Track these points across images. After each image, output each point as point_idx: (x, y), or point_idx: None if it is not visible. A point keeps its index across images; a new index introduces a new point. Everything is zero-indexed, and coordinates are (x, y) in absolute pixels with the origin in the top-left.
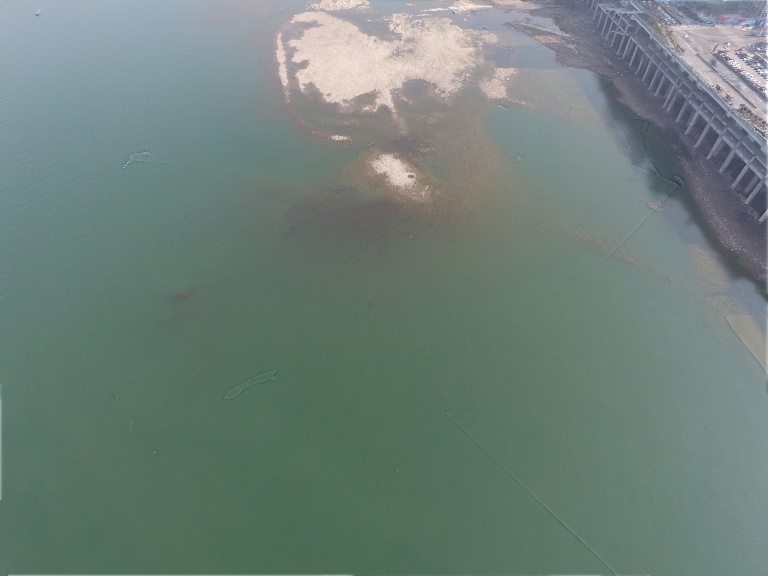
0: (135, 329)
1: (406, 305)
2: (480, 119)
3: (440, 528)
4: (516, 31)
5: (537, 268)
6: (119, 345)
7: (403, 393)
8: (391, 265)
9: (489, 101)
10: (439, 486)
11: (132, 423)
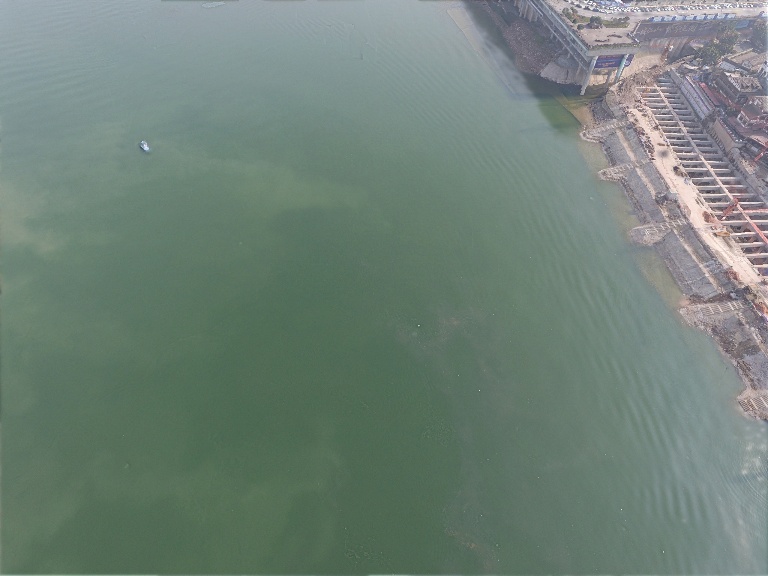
0: (151, 17)
1: (294, 19)
2: None
3: (300, 61)
4: None
5: None
6: (144, 20)
7: (288, 37)
8: None
9: None
10: (300, 50)
11: (155, 48)
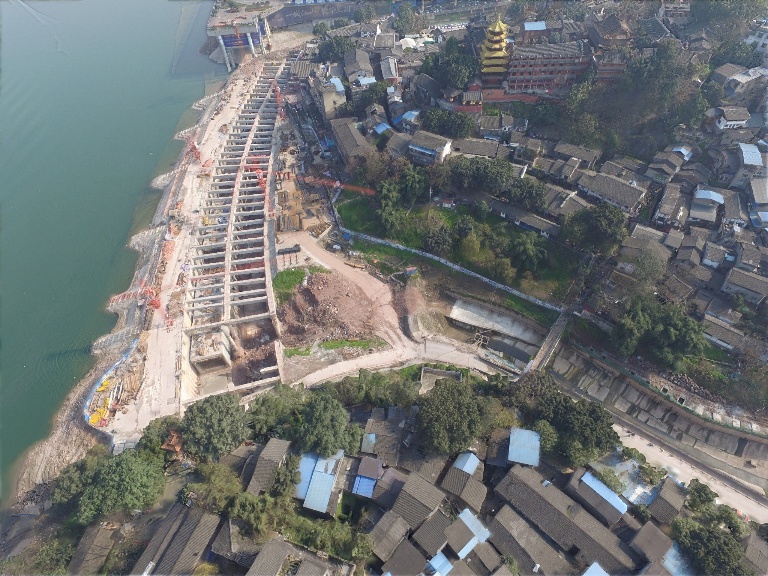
0: None
1: None
2: None
3: (19, 54)
4: None
5: (118, 1)
6: None
7: None
8: (51, 4)
9: None
10: (24, 46)
11: None
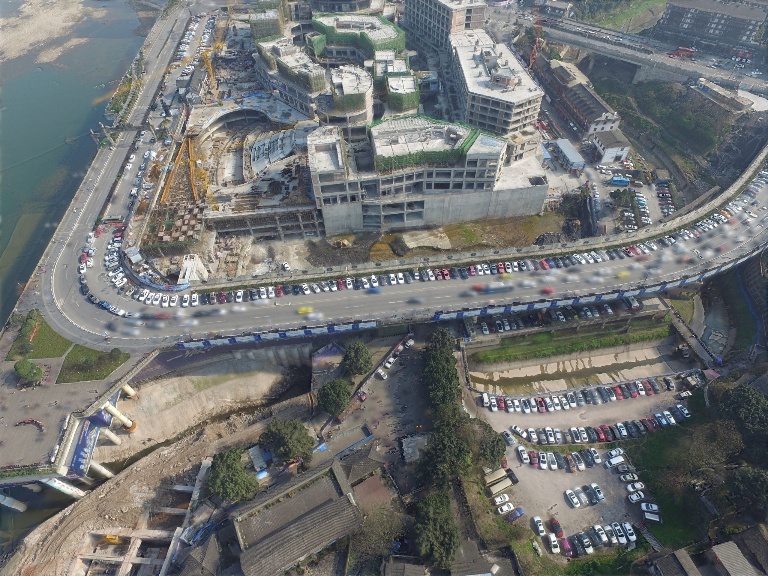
0: None
1: None
2: (8, 79)
3: None
4: (129, 8)
5: None
6: None
7: None
8: None
9: (33, 65)
10: None
11: None
